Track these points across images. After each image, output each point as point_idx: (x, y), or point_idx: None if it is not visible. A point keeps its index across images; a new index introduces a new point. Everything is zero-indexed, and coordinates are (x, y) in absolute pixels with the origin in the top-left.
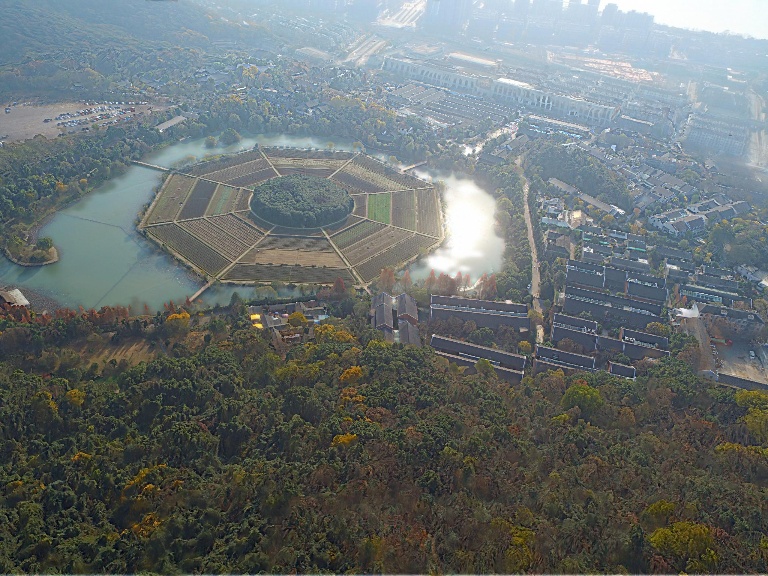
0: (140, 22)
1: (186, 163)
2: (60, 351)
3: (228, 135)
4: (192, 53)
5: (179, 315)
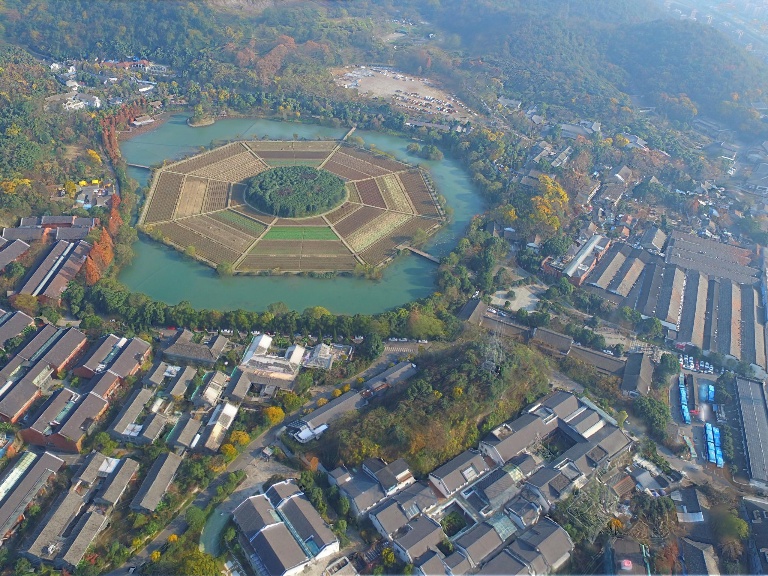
0: (650, 75)
1: (355, 141)
2: None
3: (426, 150)
4: (619, 109)
5: (92, 152)
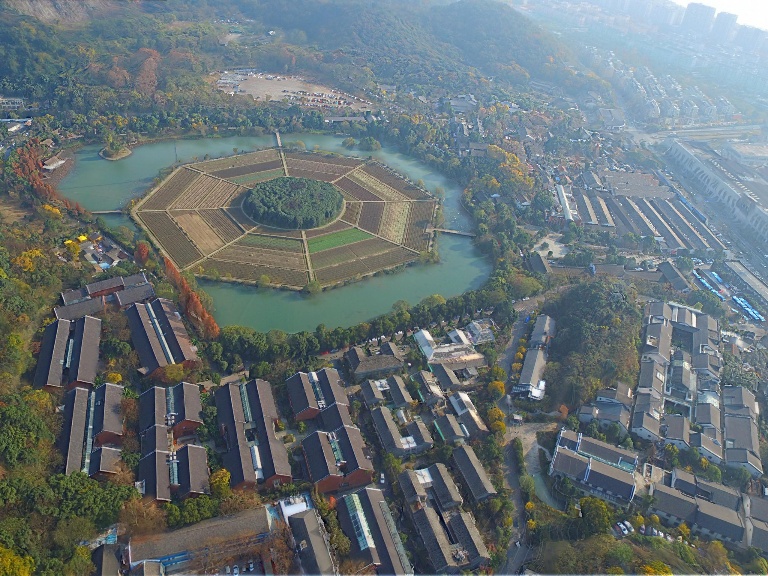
0: (479, 49)
1: (295, 146)
2: (0, 193)
3: (365, 142)
4: (479, 81)
5: (49, 207)
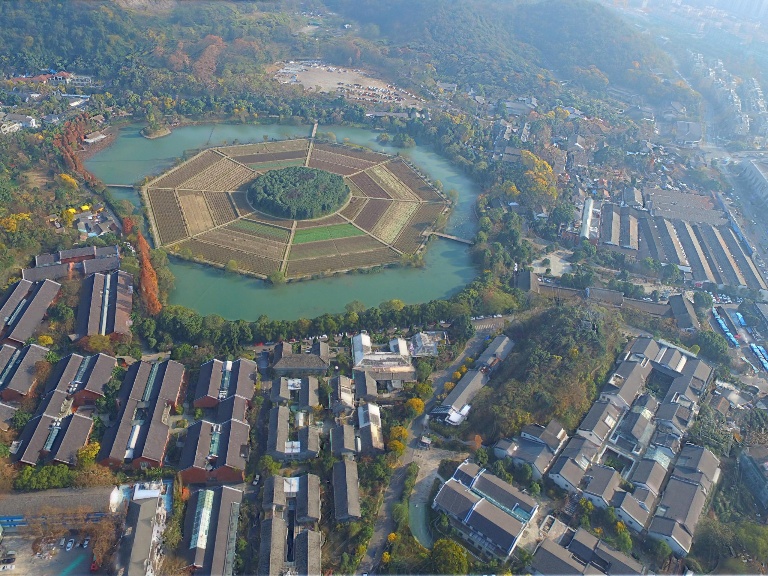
0: (559, 50)
1: (326, 137)
2: (36, 161)
3: (398, 138)
4: (546, 84)
5: (66, 176)
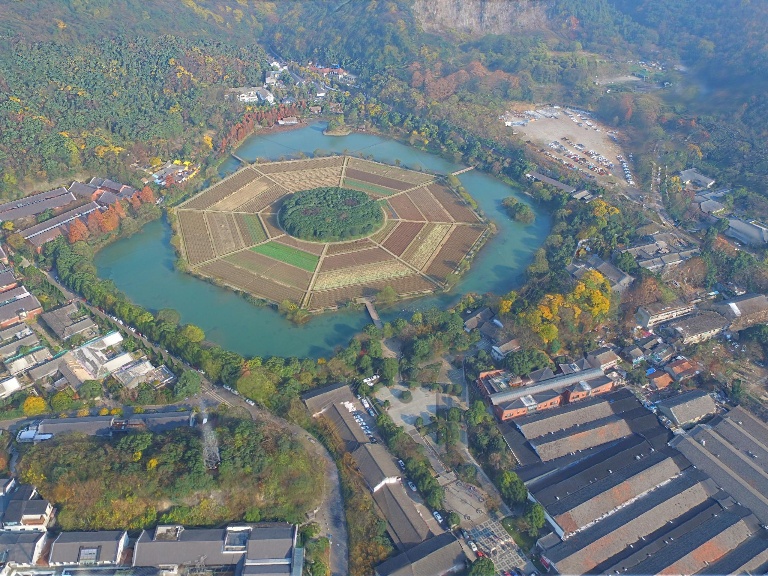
0: None
1: None
2: None
3: None
4: None
5: (207, 138)
